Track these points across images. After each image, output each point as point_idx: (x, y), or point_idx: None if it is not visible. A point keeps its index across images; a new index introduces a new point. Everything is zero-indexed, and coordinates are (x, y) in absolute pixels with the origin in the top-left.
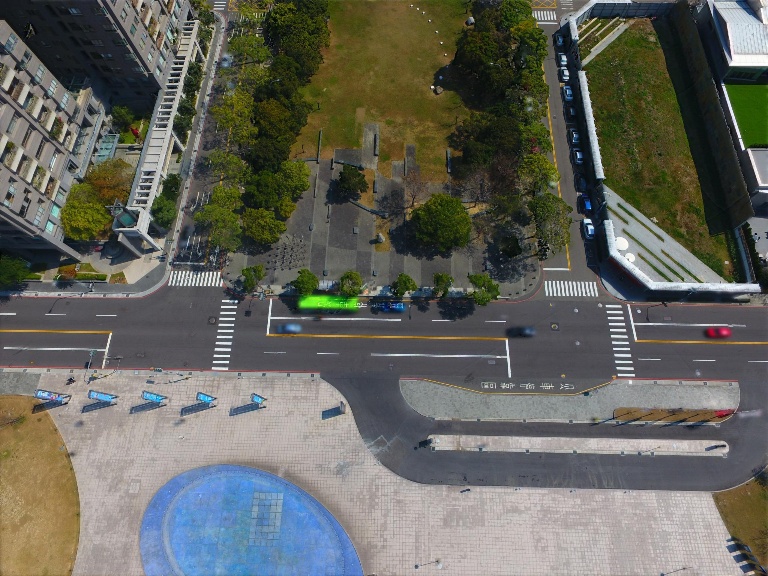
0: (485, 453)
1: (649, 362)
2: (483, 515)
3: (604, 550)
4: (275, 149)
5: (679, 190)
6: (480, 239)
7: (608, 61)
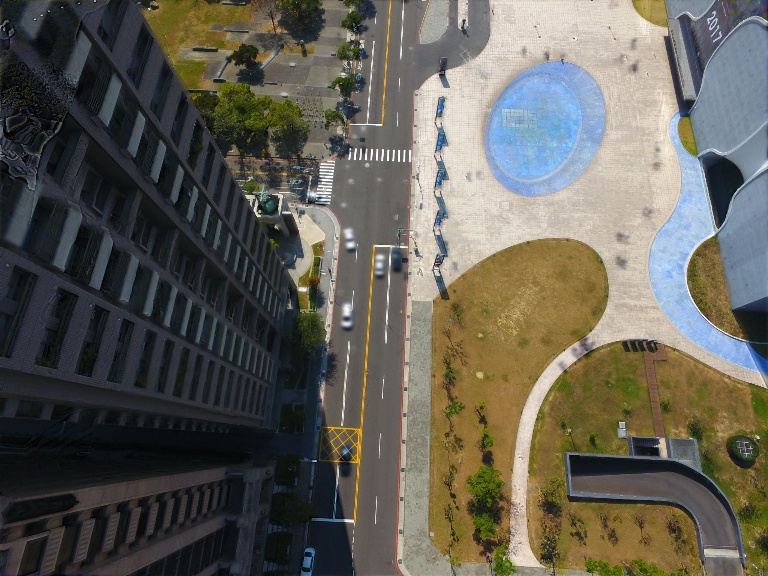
0: (469, 2)
1: None
2: (507, 5)
3: None
4: None
5: None
6: None
7: None
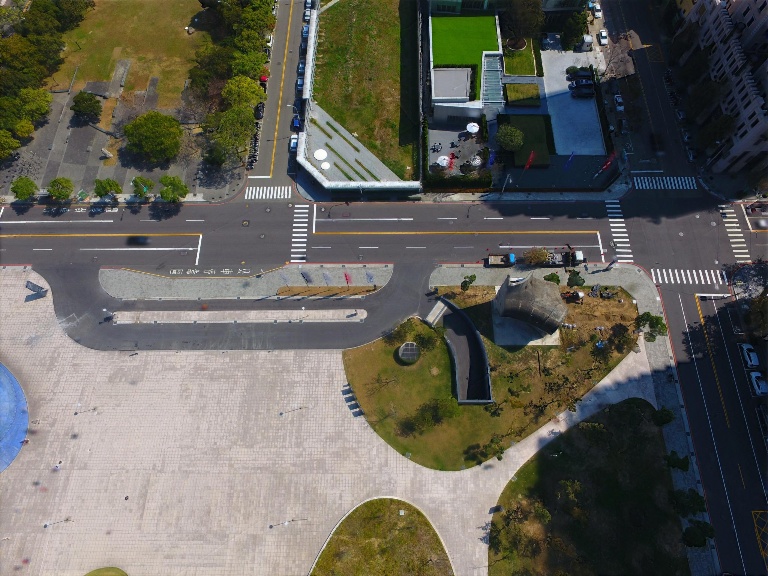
0: (158, 325)
1: (320, 250)
2: (144, 373)
3: (238, 396)
4: (15, 78)
5: (380, 109)
6: (198, 154)
7: (348, 3)
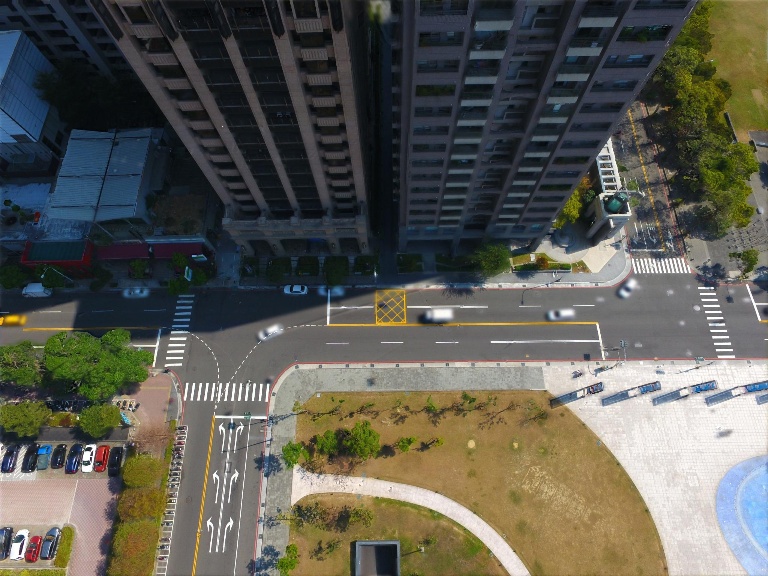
0: None
1: None
2: None
3: None
4: None
5: None
6: None
7: None
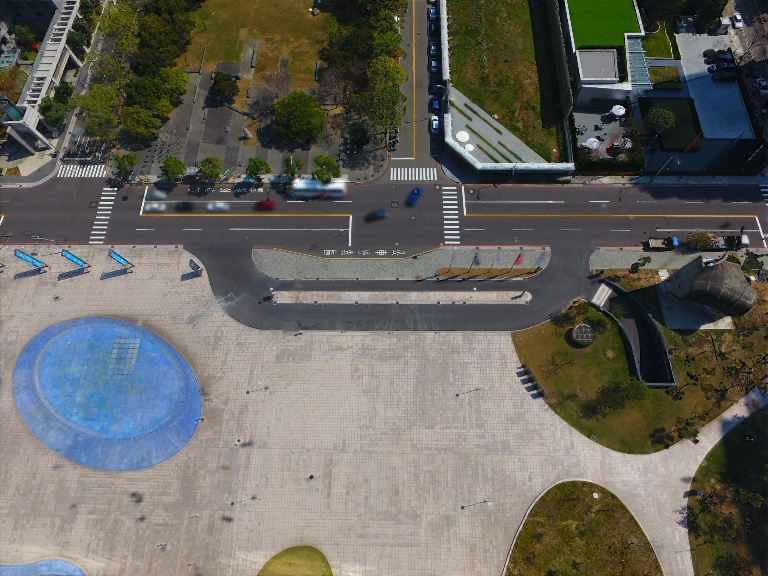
0: (319, 305)
1: (474, 232)
2: (311, 353)
3: (410, 377)
4: (154, 57)
5: (519, 91)
6: (338, 135)
7: None
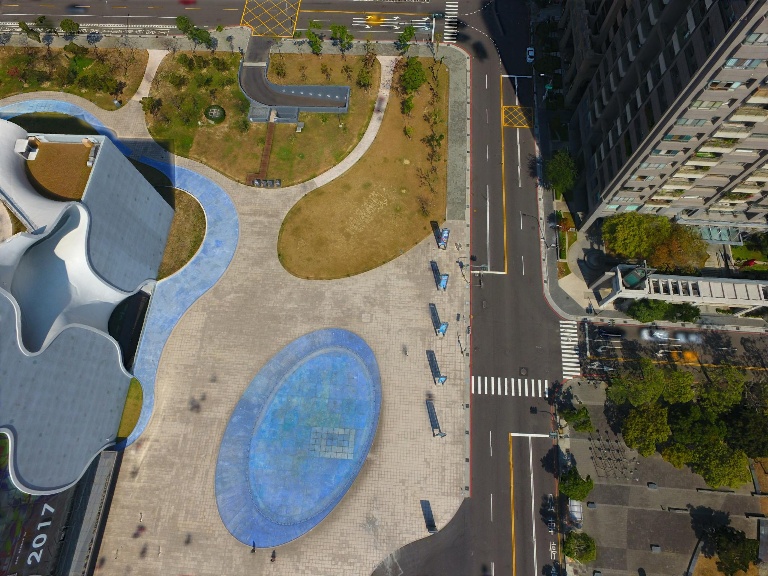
0: None
1: None
2: None
3: None
4: (763, 443)
5: None
6: None
7: None
